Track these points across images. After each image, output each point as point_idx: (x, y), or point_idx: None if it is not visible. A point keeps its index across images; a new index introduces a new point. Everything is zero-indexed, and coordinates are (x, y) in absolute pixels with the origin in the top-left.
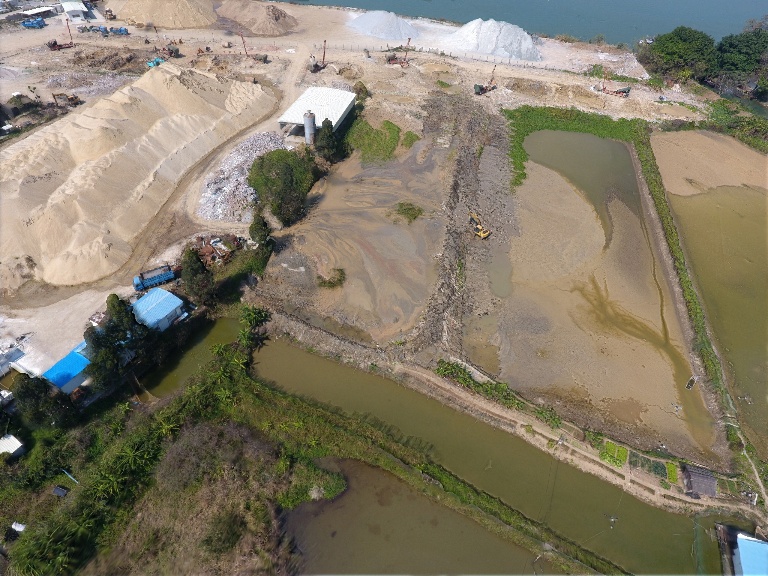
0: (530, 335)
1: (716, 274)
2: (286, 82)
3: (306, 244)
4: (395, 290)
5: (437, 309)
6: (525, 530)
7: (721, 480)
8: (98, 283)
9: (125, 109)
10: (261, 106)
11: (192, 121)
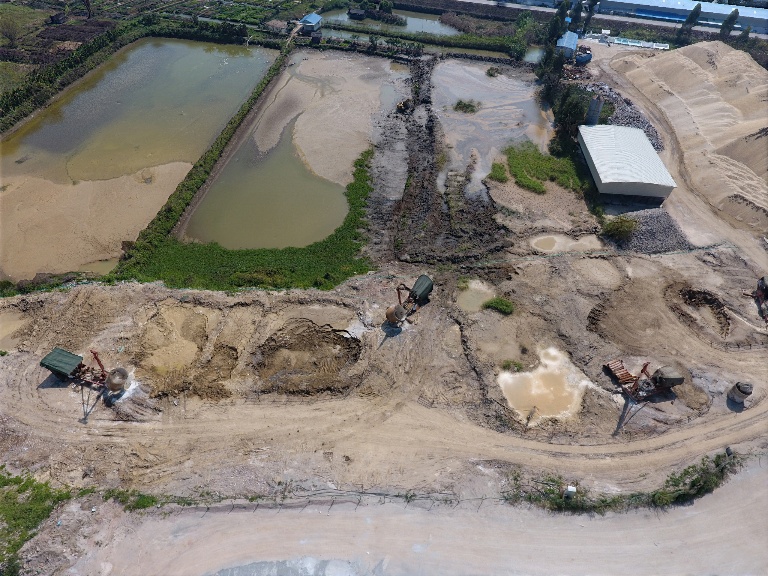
0: (373, 73)
1: (223, 105)
2: (759, 250)
3: (523, 84)
4: (454, 72)
5: (428, 65)
6: (385, 31)
7: (305, 42)
8: (610, 60)
9: (763, 92)
10: (707, 177)
11: (720, 124)
